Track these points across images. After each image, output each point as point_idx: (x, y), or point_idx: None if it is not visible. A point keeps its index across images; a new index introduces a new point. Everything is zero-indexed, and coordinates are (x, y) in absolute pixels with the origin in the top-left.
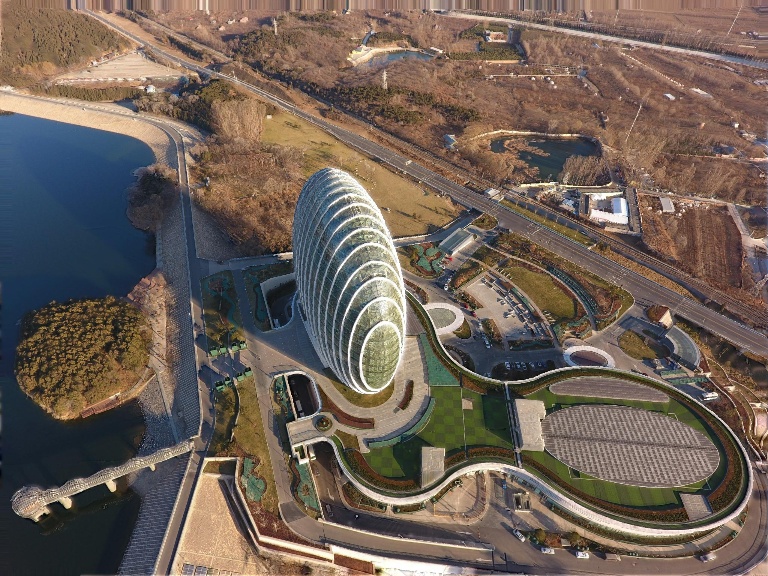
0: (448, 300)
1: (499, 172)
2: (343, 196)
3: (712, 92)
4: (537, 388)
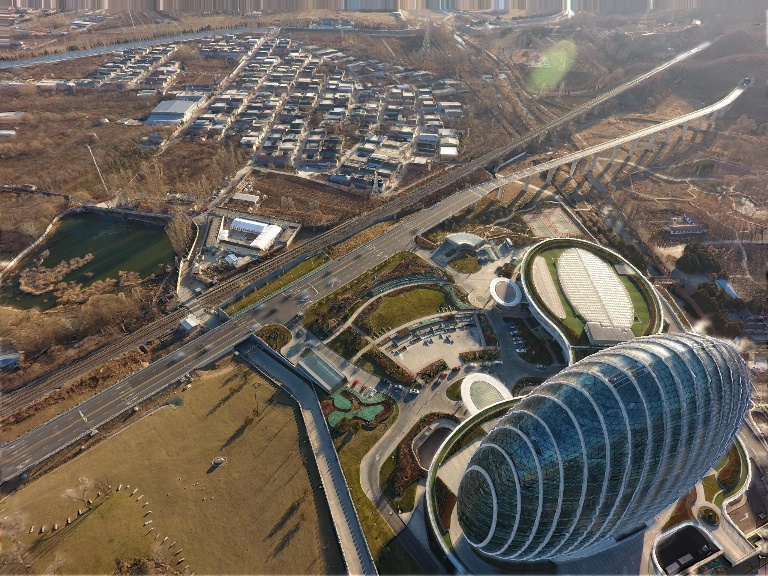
0: (437, 391)
1: (119, 311)
2: (697, 355)
3: (13, 109)
4: (567, 326)
